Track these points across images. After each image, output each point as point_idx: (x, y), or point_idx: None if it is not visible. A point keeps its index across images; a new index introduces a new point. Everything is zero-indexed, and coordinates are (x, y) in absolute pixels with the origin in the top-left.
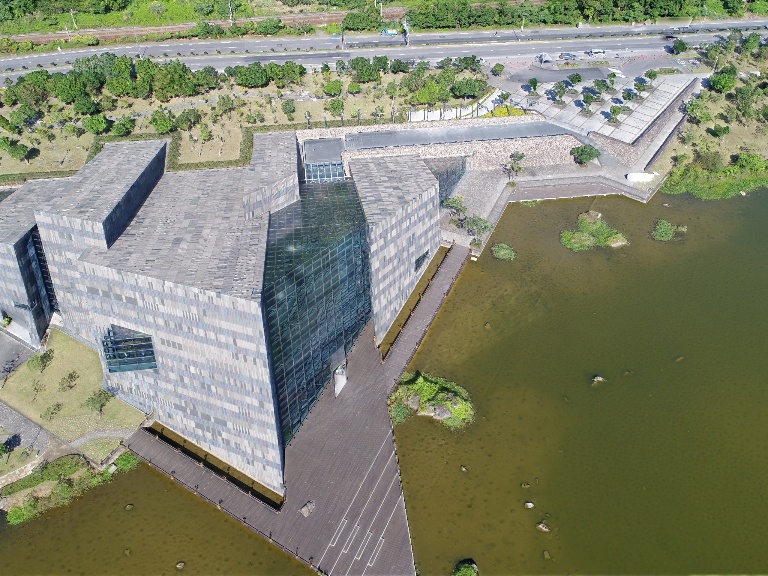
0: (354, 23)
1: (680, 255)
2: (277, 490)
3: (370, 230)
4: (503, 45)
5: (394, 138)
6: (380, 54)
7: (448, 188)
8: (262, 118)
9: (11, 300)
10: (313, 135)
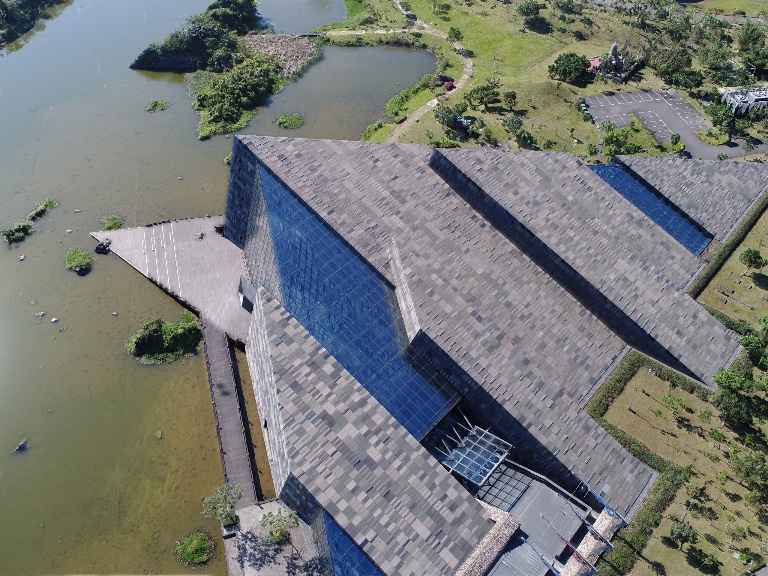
0: None
1: None
2: None
3: None
4: None
5: None
6: None
7: None
8: None
9: None
10: (594, 527)
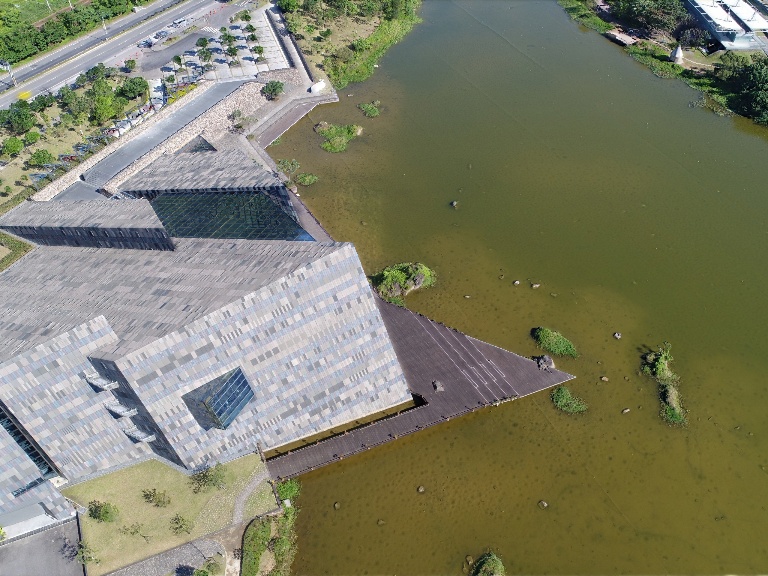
0: None
1: (396, 117)
2: (405, 399)
3: None
4: (98, 49)
5: (125, 155)
6: None
7: None
8: None
9: (7, 494)
10: (51, 193)
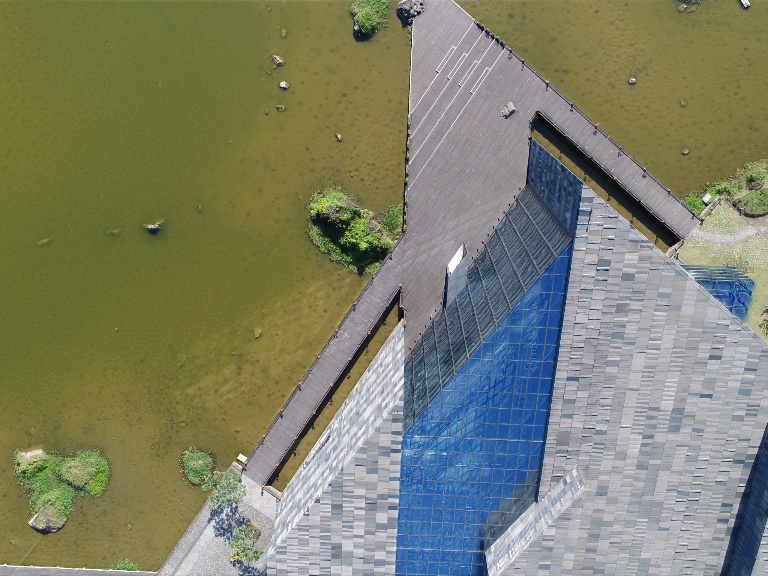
0: None
1: None
2: None
3: None
4: None
5: None
6: None
7: None
8: None
9: None
10: None
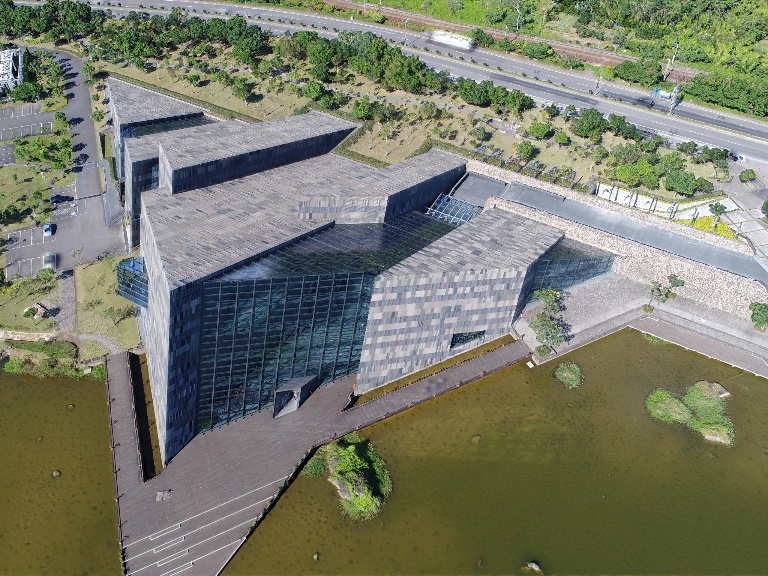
0: (626, 72)
1: None
2: (163, 464)
3: (375, 278)
4: None
5: (558, 204)
6: (630, 113)
7: (569, 279)
8: (452, 135)
9: (129, 206)
10: (482, 169)
